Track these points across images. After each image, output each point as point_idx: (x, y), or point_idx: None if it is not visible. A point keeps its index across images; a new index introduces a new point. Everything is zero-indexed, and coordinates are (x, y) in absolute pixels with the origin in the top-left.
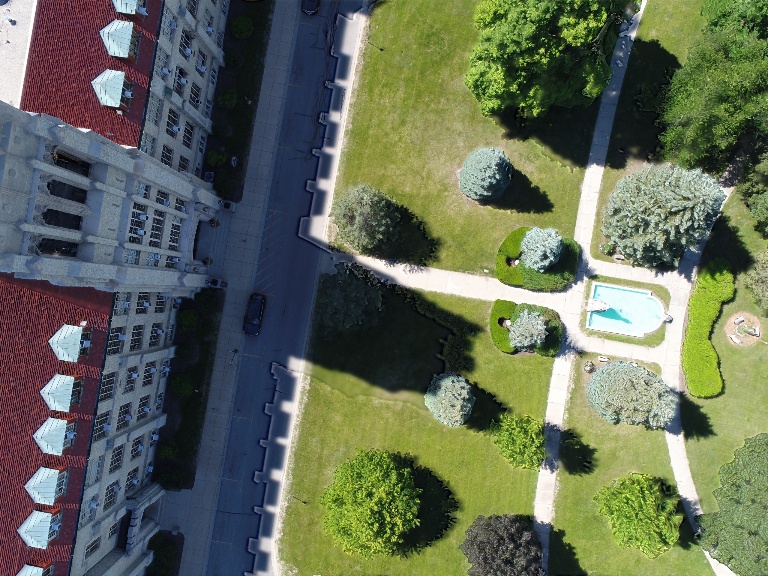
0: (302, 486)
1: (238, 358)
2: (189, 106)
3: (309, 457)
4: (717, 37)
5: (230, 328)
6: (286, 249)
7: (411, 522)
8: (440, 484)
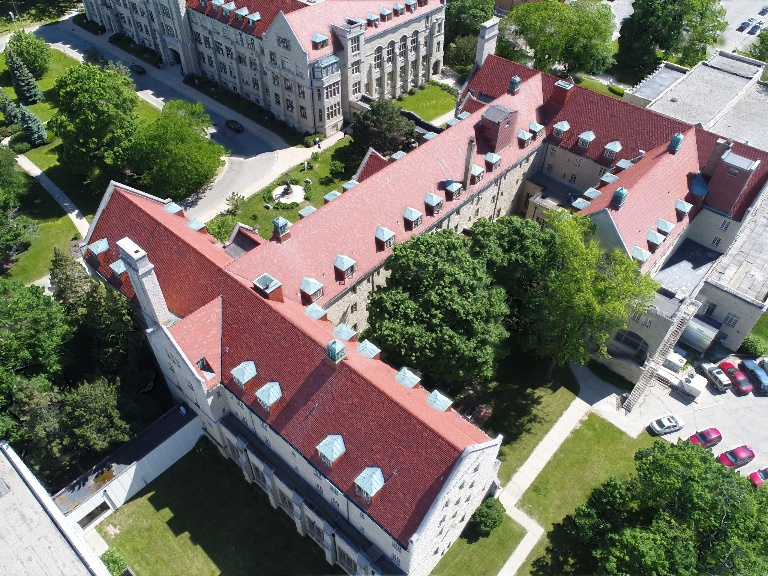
0: (66, 60)
1: (131, 63)
2: (213, 53)
3: (72, 64)
4: (5, 156)
5: (143, 65)
6: (149, 85)
7: (5, 53)
8: (8, 86)
